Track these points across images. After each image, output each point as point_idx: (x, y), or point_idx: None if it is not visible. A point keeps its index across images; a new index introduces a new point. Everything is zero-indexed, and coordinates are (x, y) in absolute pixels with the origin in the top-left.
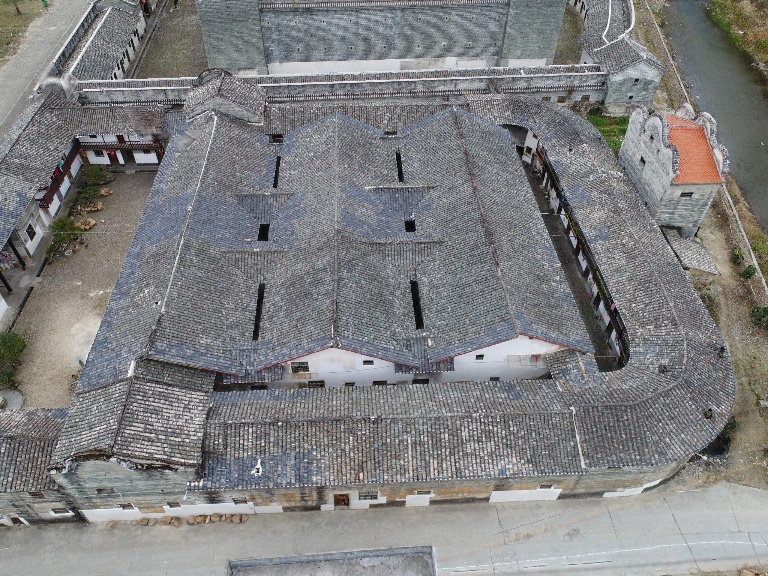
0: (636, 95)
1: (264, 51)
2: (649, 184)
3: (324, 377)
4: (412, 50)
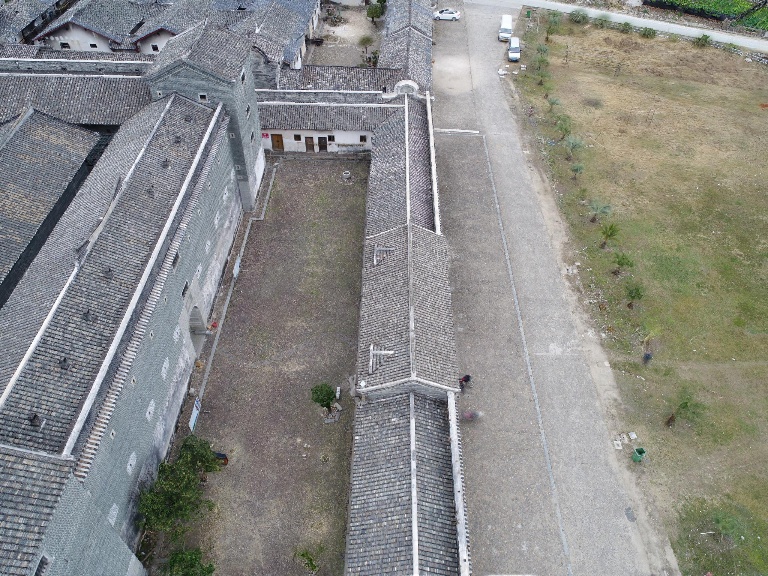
0: None
1: None
2: None
3: None
4: None
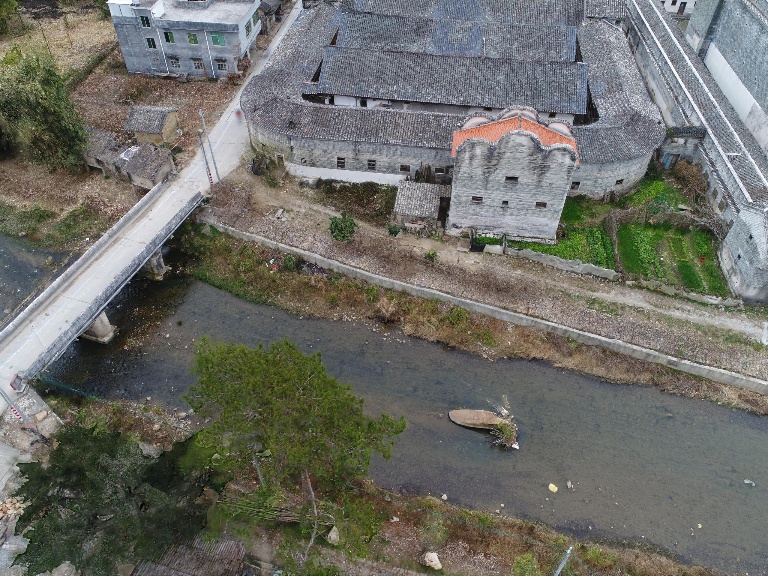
0: None
1: (711, 26)
2: None
3: None
4: (765, 97)
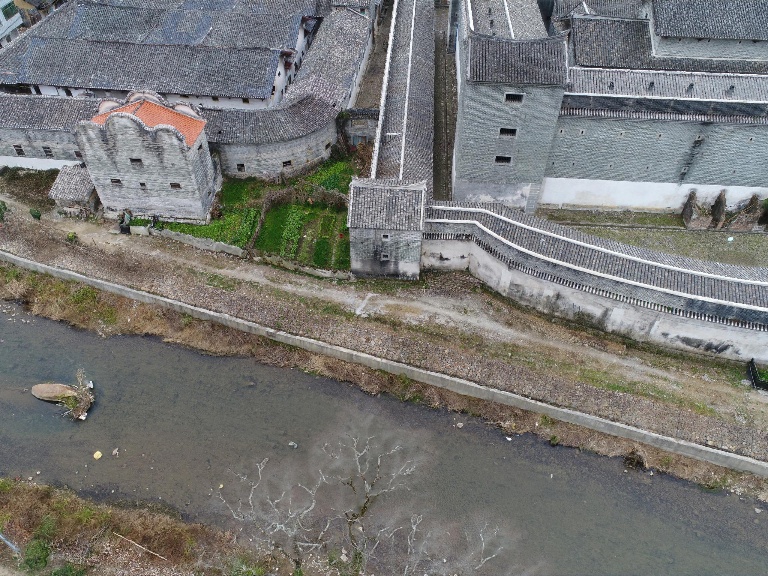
0: None
1: (453, 13)
2: None
3: None
4: None
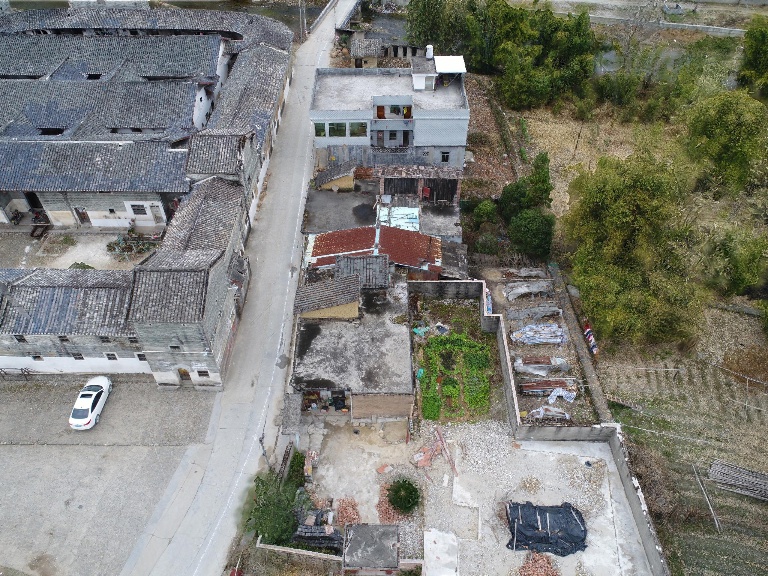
0: (2, 5)
1: None
2: (118, 5)
3: (197, 125)
4: None
